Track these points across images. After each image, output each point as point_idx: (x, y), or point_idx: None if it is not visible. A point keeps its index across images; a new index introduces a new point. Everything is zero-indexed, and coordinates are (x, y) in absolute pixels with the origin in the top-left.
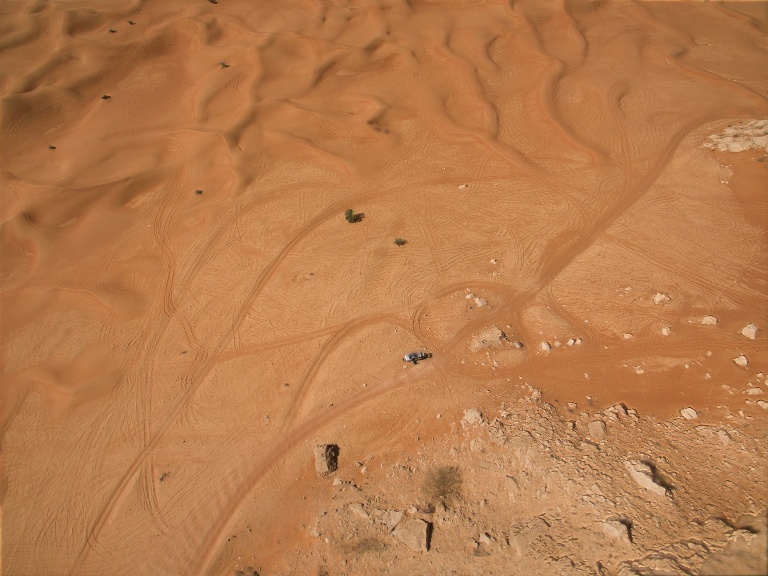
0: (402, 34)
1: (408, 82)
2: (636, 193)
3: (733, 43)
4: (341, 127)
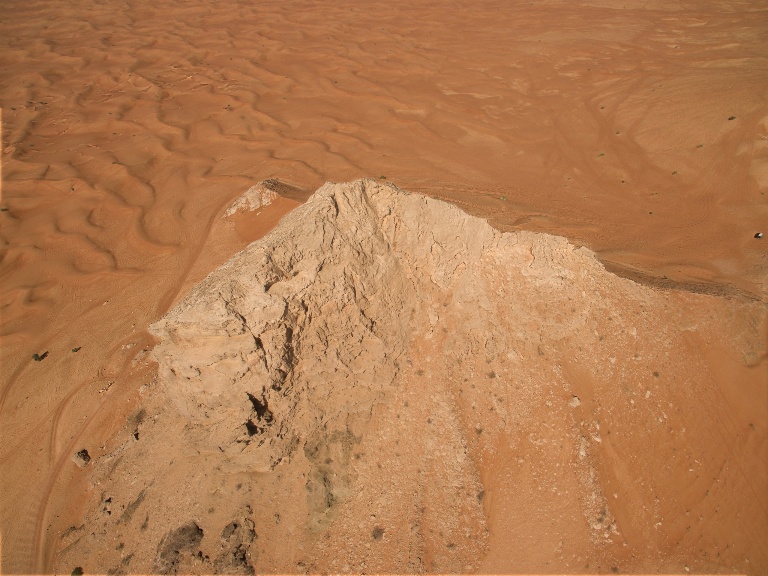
0: (19, 239)
1: (41, 266)
2: (196, 256)
3: (236, 153)
4: (4, 317)
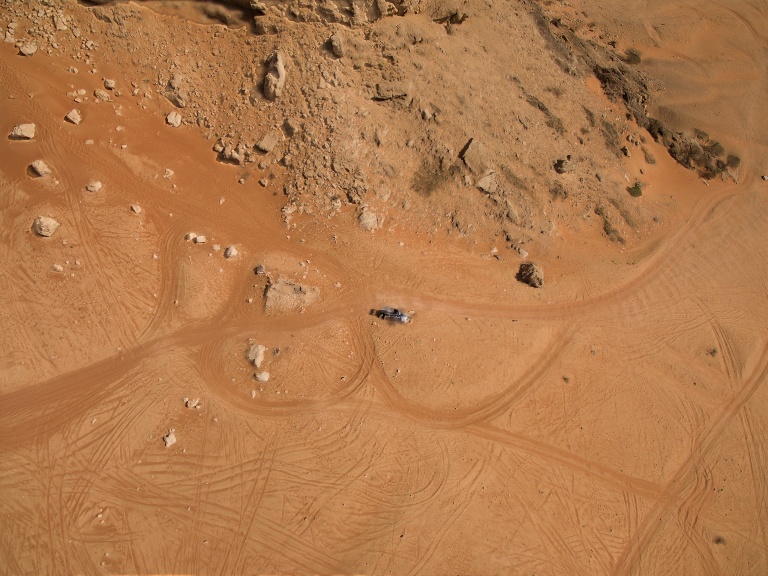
0: None
1: None
2: None
3: None
4: None
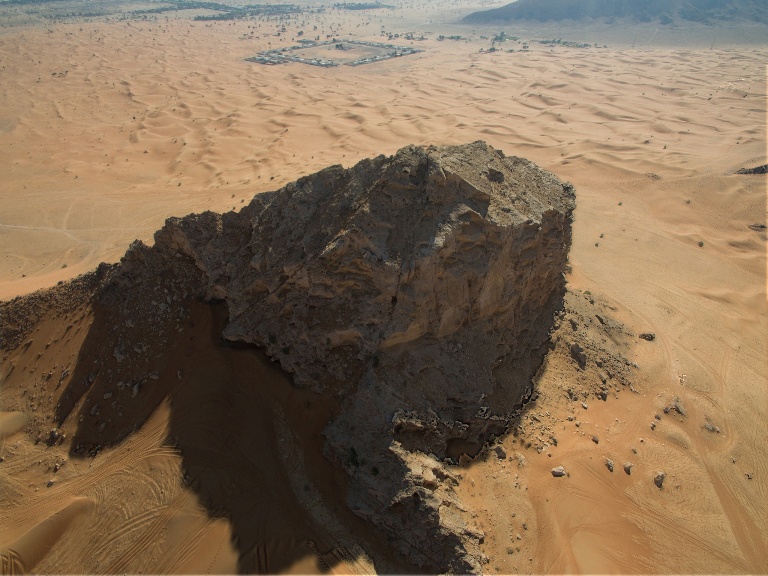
0: None
1: None
2: None
3: None
4: None
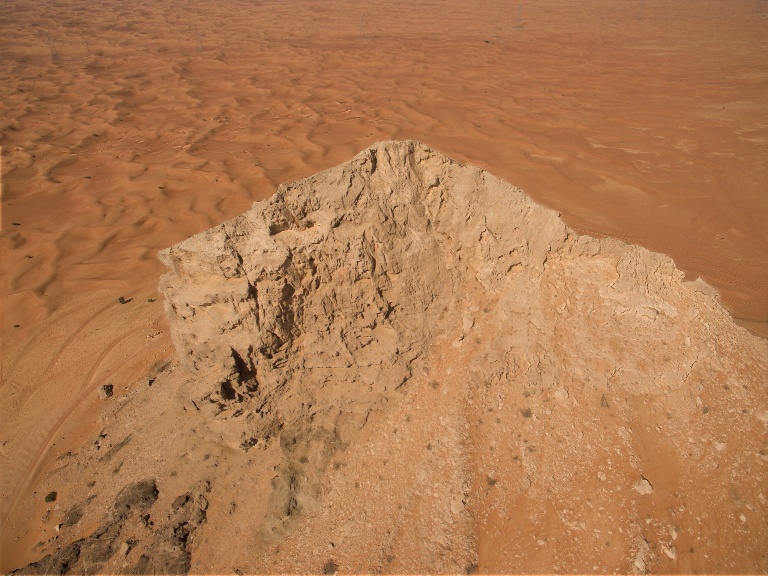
0: (161, 211)
1: (166, 234)
2: None
3: None
4: (120, 266)
